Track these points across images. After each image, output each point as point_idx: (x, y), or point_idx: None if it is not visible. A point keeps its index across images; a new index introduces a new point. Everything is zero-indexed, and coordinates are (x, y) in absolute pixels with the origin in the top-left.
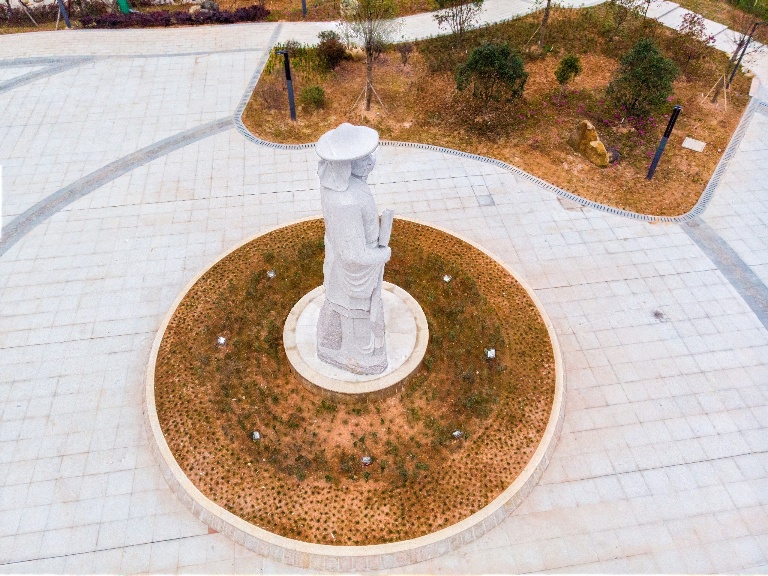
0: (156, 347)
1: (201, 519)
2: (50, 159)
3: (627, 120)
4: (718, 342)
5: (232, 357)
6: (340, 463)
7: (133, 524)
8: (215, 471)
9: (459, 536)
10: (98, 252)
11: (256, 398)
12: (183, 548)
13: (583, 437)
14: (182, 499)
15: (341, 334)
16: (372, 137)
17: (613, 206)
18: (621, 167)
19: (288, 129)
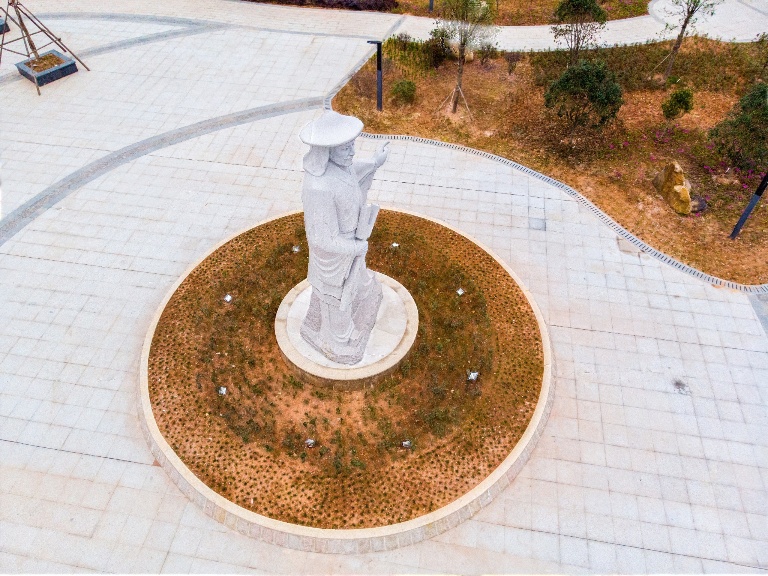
0: (173, 290)
1: (152, 450)
2: (157, 108)
3: (731, 170)
4: (739, 432)
5: (231, 315)
6: (286, 438)
7: (97, 437)
8: (177, 412)
9: (368, 541)
10: (162, 197)
11: (237, 357)
12: (128, 470)
13: (539, 486)
14: (143, 428)
15: (321, 317)
16: (354, 128)
17: (677, 259)
18: (705, 219)
19: (371, 118)
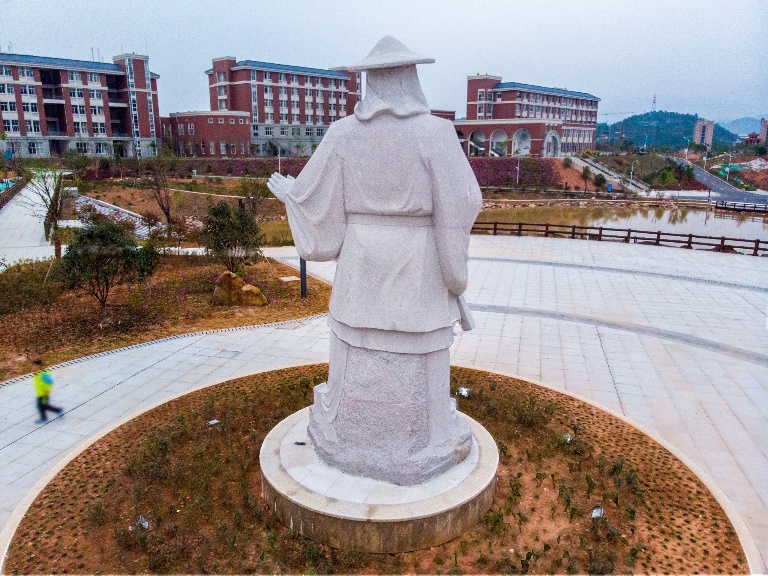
0: None
1: None
2: None
3: None
4: (494, 326)
5: None
6: None
7: None
8: None
9: None
10: None
11: None
12: None
13: None
14: None
15: (427, 406)
16: None
17: (316, 315)
18: (275, 301)
19: None
